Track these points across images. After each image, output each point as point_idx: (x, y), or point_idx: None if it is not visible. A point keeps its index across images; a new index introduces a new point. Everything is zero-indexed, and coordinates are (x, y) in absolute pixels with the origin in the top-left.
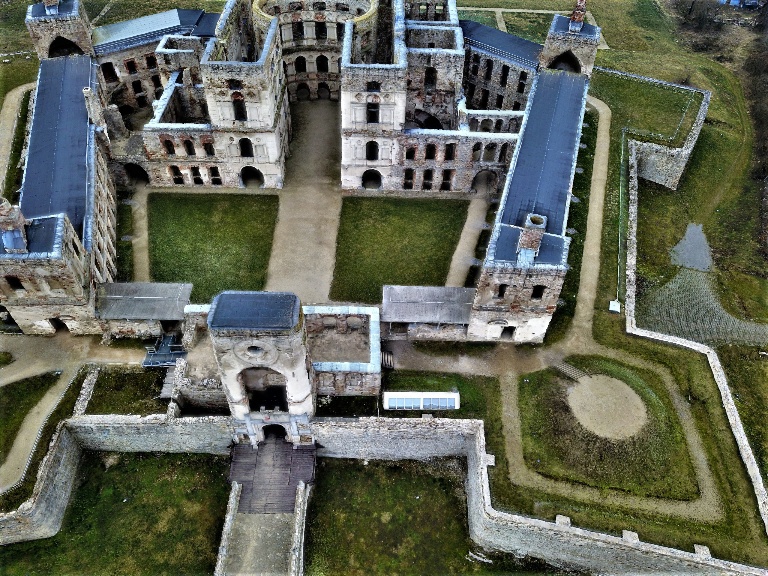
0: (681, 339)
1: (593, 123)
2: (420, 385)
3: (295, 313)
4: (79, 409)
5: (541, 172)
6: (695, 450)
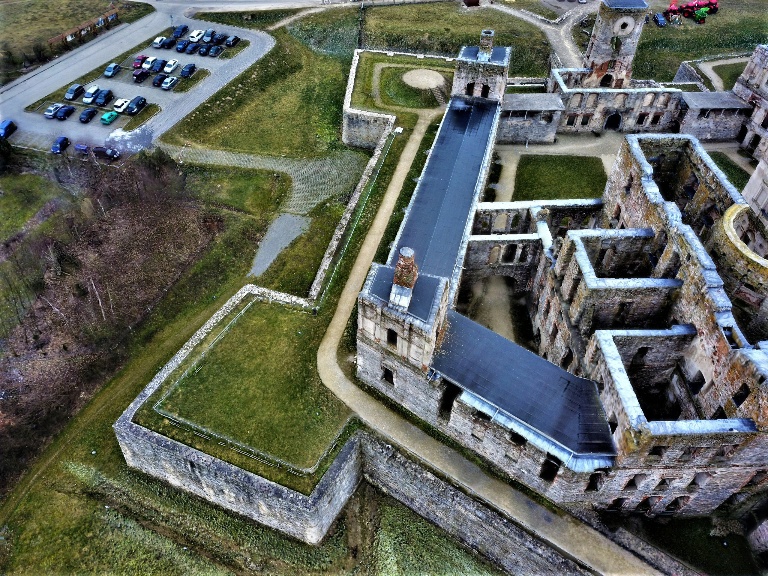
0: (362, 113)
1: (354, 325)
2: (525, 91)
3: (606, 2)
4: (700, 84)
5: (458, 157)
6: (377, 80)
